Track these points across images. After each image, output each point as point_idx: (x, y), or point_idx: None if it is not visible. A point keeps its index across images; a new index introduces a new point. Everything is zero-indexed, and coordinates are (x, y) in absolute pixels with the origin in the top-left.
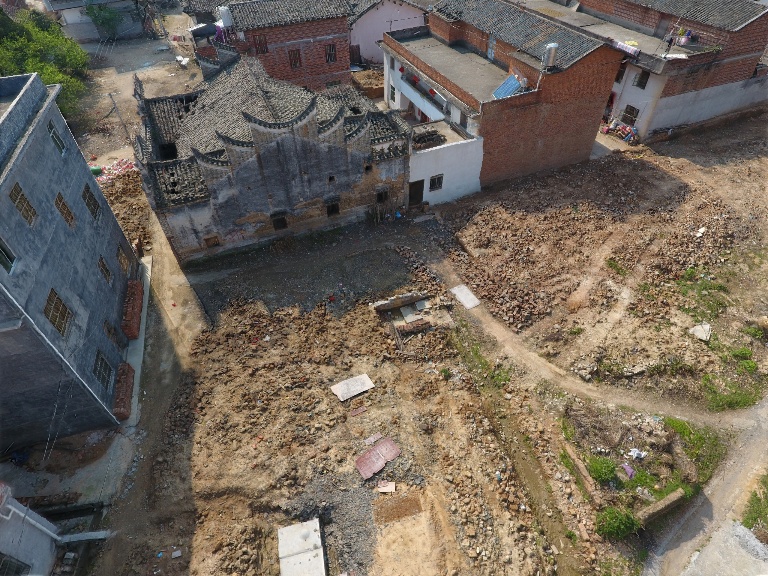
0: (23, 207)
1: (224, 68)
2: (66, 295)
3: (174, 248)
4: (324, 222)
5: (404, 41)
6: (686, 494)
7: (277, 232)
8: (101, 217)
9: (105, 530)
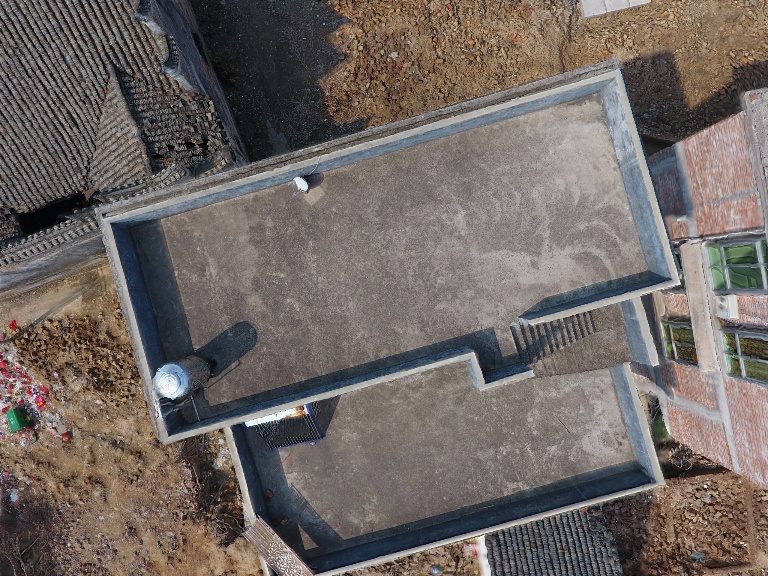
0: None
1: None
2: None
3: None
4: (187, 6)
5: None
6: None
7: None
8: None
9: None
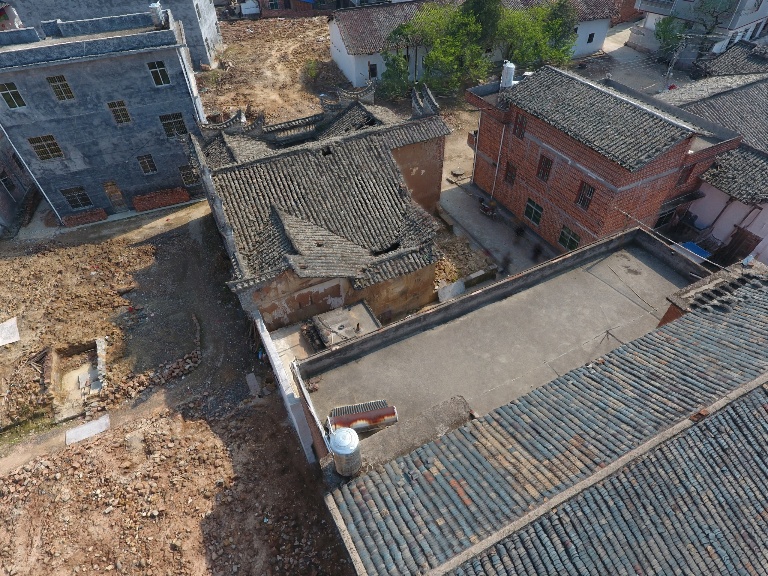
0: (59, 89)
1: None
2: (67, 146)
3: None
4: None
5: (654, 265)
6: None
7: None
8: None
9: None
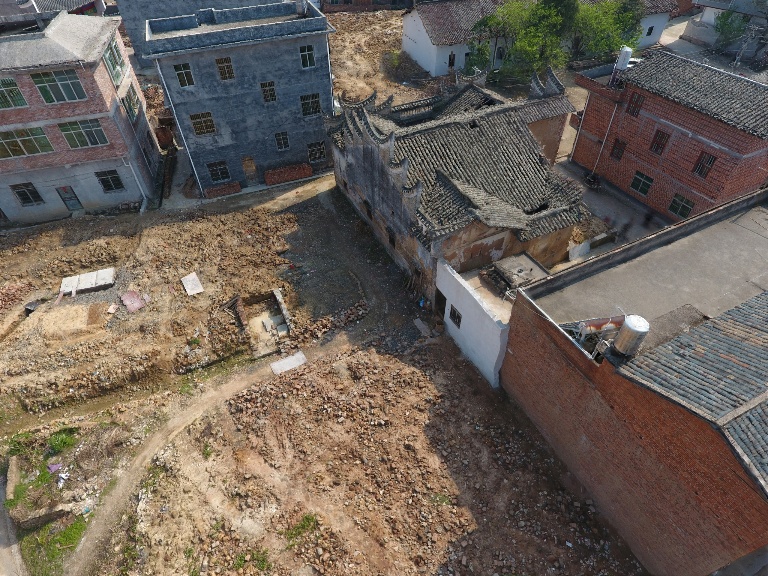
0: (224, 69)
1: (542, 98)
2: (220, 123)
3: None
4: None
5: None
6: (5, 500)
7: None
8: (314, 117)
9: (145, 211)
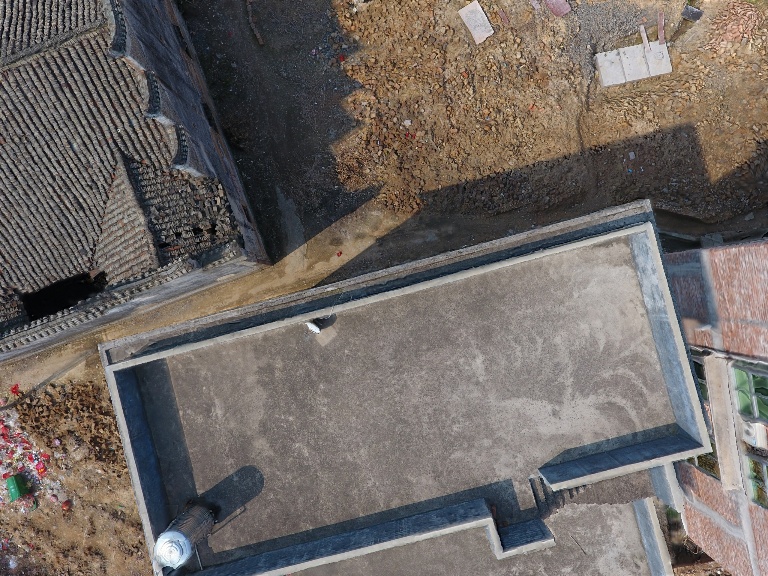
0: None
1: None
2: None
3: (262, 261)
4: (198, 71)
5: None
6: None
7: (220, 134)
8: None
9: None
